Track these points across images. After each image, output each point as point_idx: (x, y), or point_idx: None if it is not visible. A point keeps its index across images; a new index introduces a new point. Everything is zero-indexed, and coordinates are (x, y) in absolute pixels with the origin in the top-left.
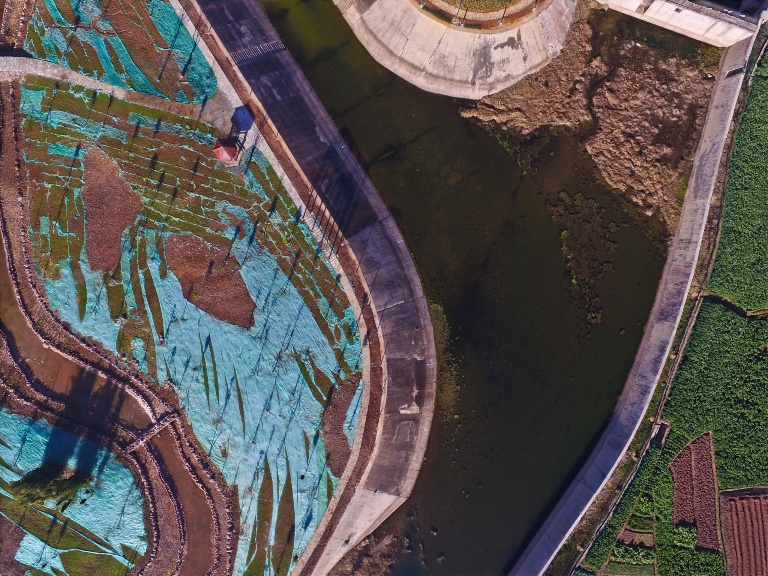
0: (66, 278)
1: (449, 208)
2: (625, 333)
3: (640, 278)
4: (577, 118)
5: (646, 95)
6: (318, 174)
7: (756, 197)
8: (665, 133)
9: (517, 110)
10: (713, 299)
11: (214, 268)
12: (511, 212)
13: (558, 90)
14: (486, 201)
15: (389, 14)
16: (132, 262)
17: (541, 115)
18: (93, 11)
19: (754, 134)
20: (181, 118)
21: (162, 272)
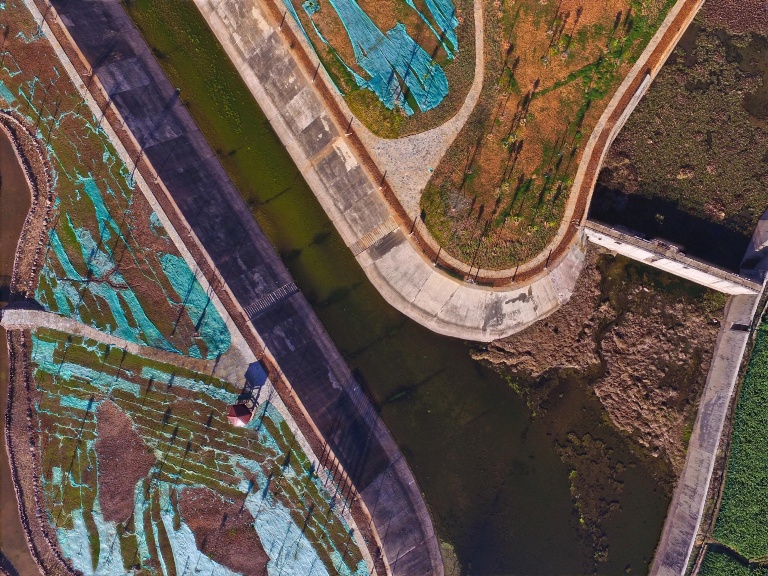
0: (79, 528)
1: (460, 448)
2: (631, 570)
3: (646, 516)
4: (586, 361)
5: (653, 340)
6: (331, 426)
7: (759, 450)
8: (671, 376)
9: (527, 354)
10: (717, 546)
11: (228, 521)
12: (520, 452)
13: (567, 335)
14: (496, 441)
15: (402, 266)
16: (145, 514)
17: (551, 359)
18: (106, 265)
19: (758, 388)
20: (195, 373)
21: (175, 524)
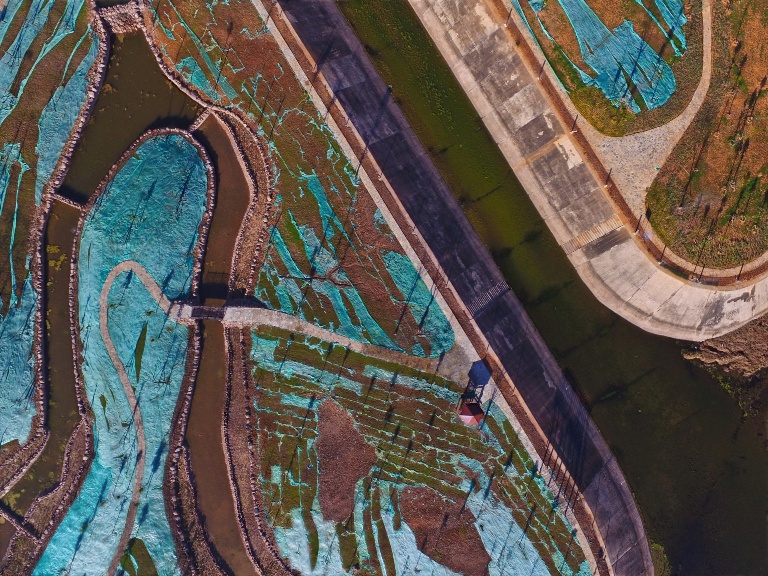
0: (297, 527)
1: (670, 448)
2: None
3: None
4: None
5: None
6: (551, 425)
7: None
8: None
9: (740, 353)
10: None
11: (449, 520)
12: (731, 452)
13: None
14: (707, 441)
15: (622, 265)
16: (365, 513)
17: (764, 359)
18: (329, 262)
19: None
20: (418, 372)
21: (396, 523)
